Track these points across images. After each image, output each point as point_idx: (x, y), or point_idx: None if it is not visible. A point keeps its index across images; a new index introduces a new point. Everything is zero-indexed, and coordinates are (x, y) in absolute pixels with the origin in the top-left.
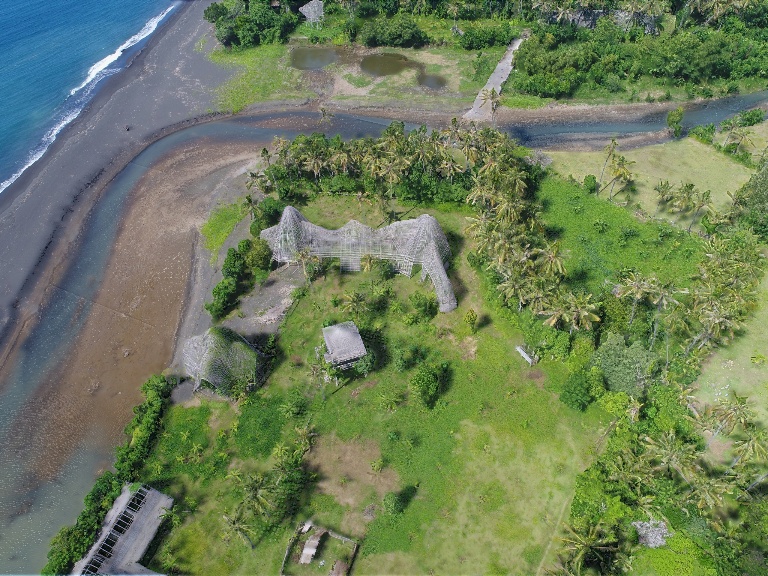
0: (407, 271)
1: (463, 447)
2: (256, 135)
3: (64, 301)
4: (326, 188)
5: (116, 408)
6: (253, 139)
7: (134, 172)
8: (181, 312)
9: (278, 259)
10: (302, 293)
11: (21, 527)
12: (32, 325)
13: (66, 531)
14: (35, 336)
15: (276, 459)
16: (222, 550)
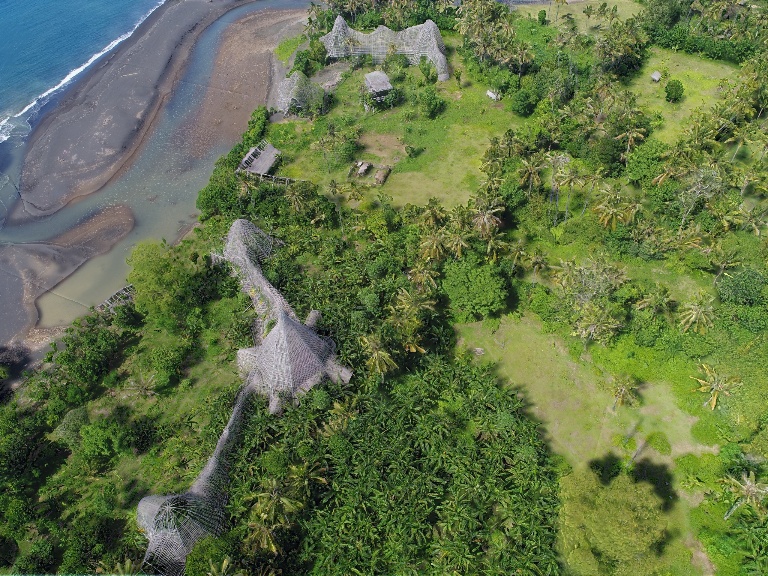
0: (417, 62)
1: (452, 134)
2: (305, 4)
3: (187, 87)
4: (360, 24)
5: (234, 130)
6: (303, 6)
7: (220, 25)
8: (267, 89)
9: (331, 55)
10: (348, 75)
11: (188, 175)
12: (169, 97)
13: (224, 157)
14: (173, 102)
15: (339, 142)
16: (311, 174)
